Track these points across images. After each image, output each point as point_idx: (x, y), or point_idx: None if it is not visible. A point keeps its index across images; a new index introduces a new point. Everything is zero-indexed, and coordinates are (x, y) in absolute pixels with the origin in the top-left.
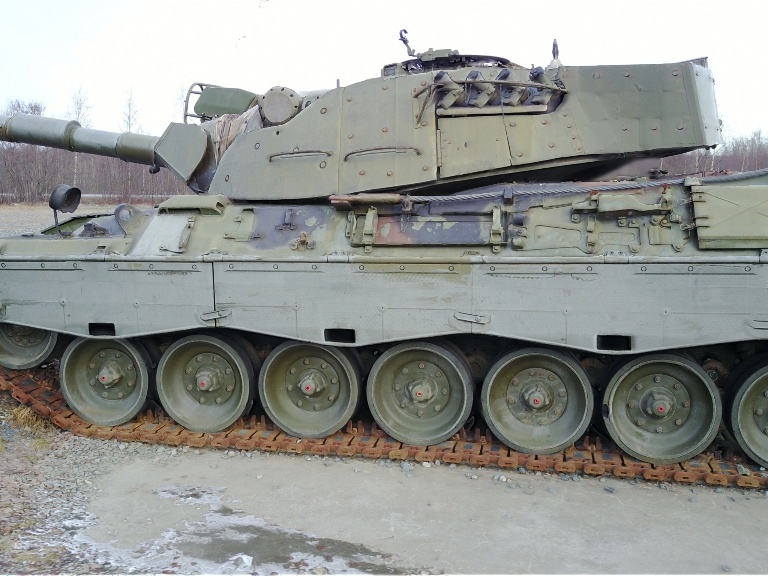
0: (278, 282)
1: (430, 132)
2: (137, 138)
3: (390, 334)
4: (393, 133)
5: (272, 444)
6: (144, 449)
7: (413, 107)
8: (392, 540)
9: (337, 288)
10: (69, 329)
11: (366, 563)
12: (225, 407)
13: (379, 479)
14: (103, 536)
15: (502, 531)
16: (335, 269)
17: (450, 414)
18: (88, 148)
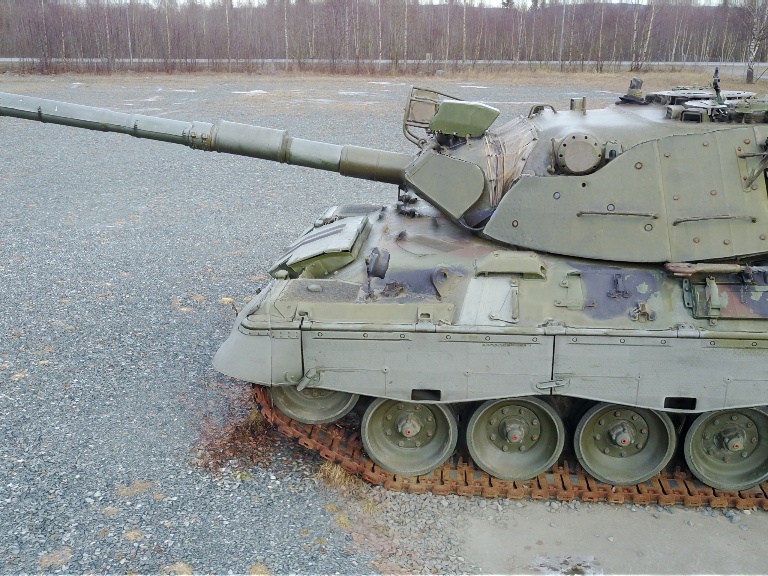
0: (623, 355)
1: (762, 197)
2: (362, 153)
3: (732, 402)
4: (723, 197)
5: (594, 495)
6: (466, 504)
7: (740, 168)
8: None
9: (684, 361)
10: (390, 395)
11: None
12: (530, 455)
13: (721, 535)
14: None
15: None
16: (685, 344)
17: (758, 460)
18: (306, 162)
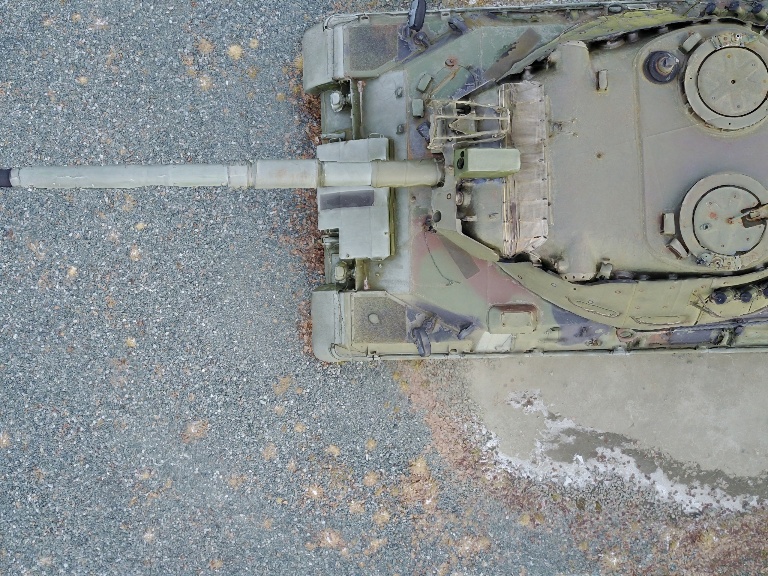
0: None
1: None
2: (390, 180)
3: None
4: None
5: None
6: None
7: (691, 297)
8: (634, 428)
9: None
10: None
11: (628, 449)
12: None
13: (613, 363)
14: (511, 452)
15: (680, 408)
16: None
17: None
18: None
